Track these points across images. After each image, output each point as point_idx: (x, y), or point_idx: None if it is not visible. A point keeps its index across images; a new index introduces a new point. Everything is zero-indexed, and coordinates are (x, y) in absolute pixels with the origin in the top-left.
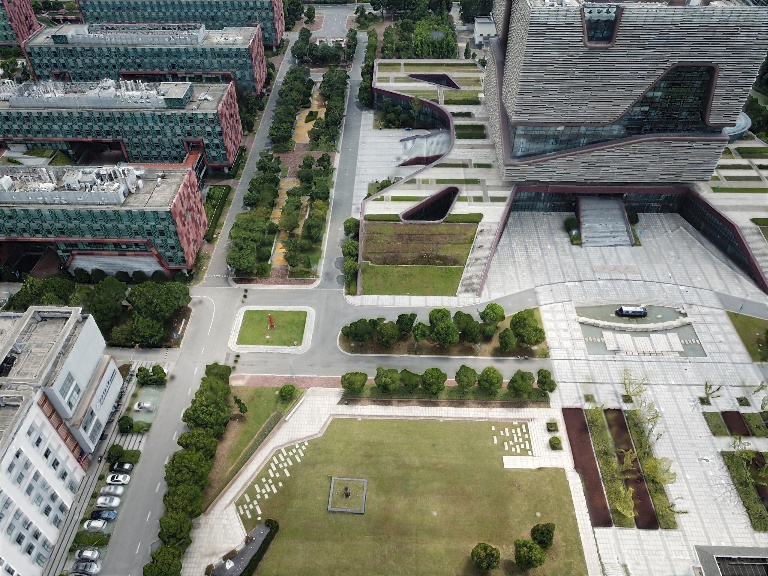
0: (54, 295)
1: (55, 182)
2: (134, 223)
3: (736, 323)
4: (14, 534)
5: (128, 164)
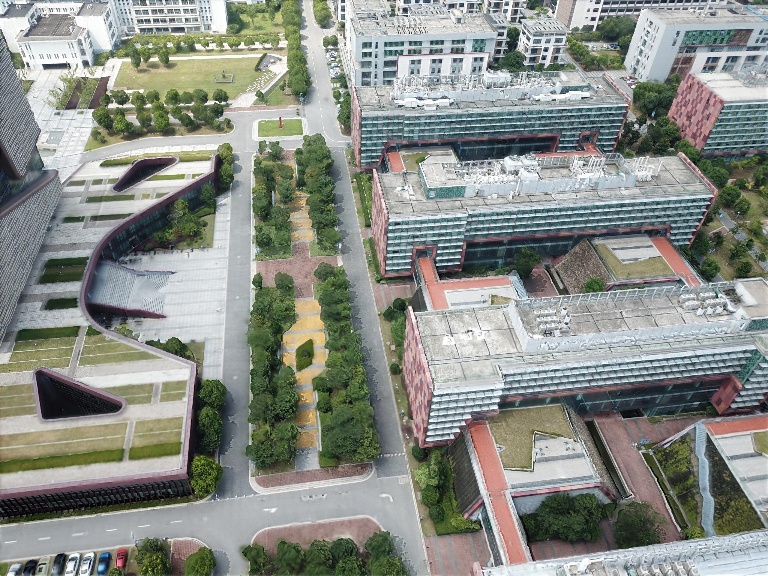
0: None
1: None
2: None
3: None
4: None
5: None
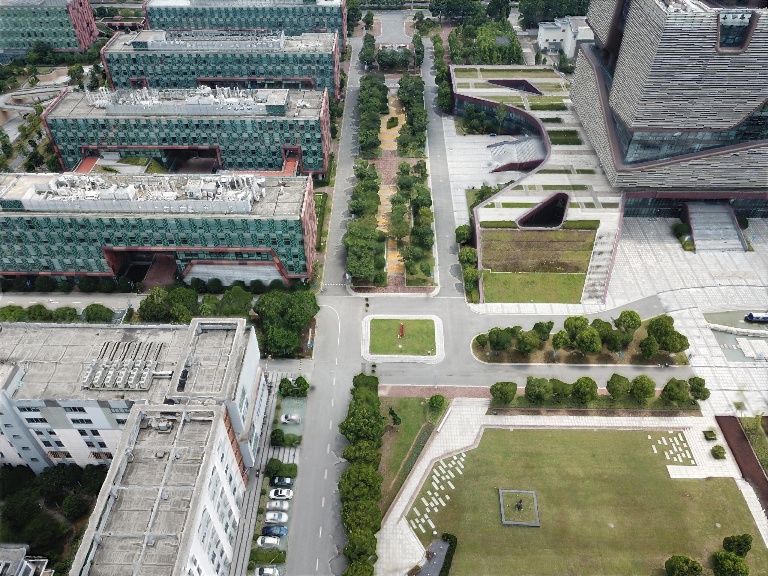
0: (183, 306)
1: (176, 191)
2: (260, 232)
3: None
4: (210, 553)
5: (227, 172)
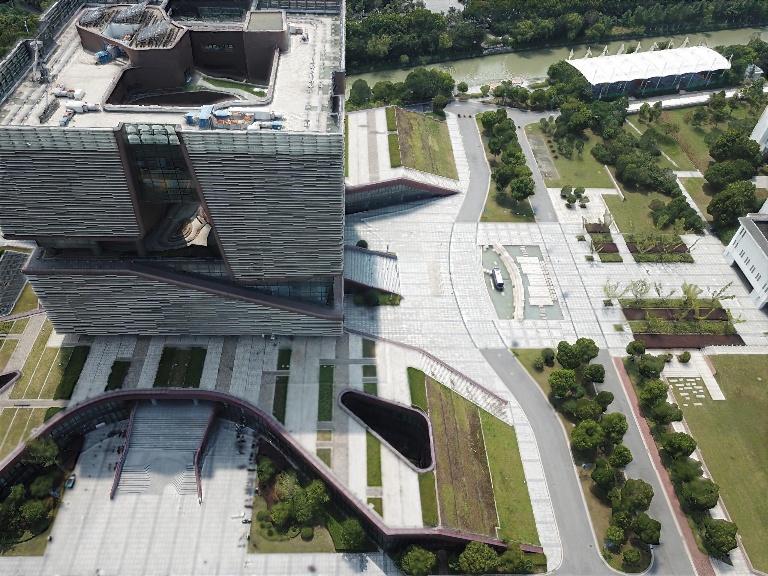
0: None
1: None
2: None
3: (495, 220)
4: None
5: None
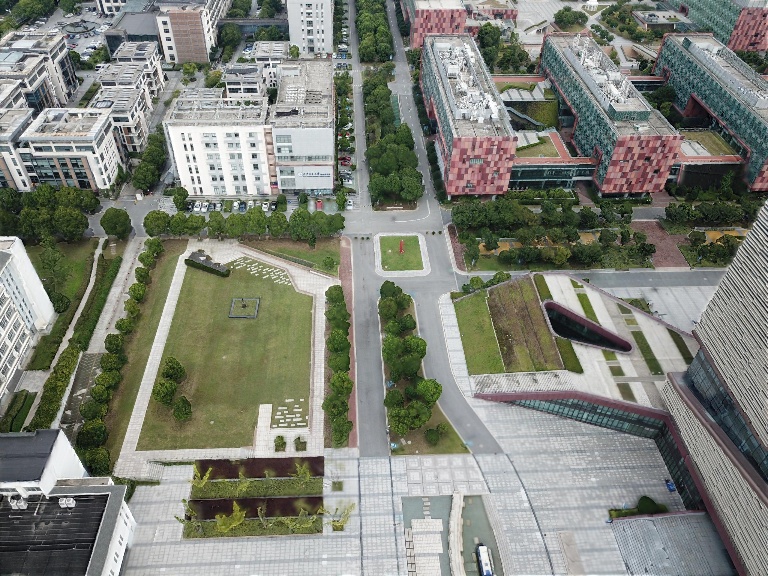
0: (393, 137)
1: None
2: None
3: None
4: (211, 161)
5: (556, 132)
